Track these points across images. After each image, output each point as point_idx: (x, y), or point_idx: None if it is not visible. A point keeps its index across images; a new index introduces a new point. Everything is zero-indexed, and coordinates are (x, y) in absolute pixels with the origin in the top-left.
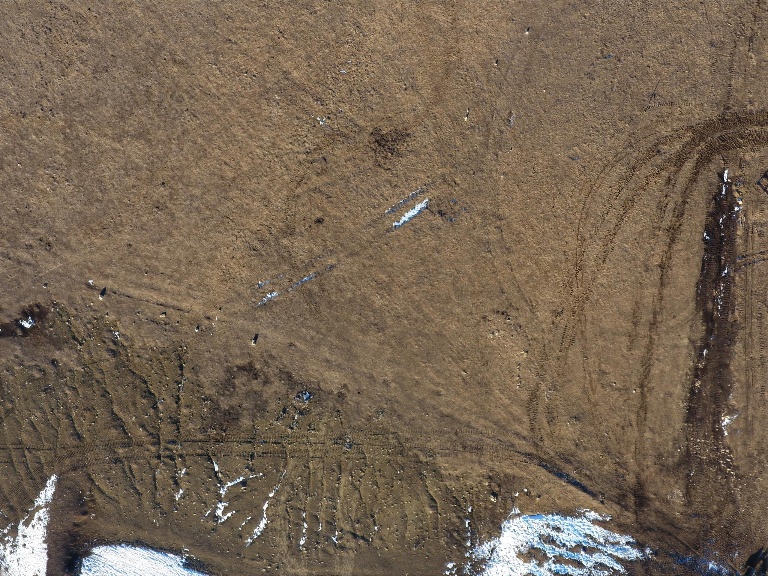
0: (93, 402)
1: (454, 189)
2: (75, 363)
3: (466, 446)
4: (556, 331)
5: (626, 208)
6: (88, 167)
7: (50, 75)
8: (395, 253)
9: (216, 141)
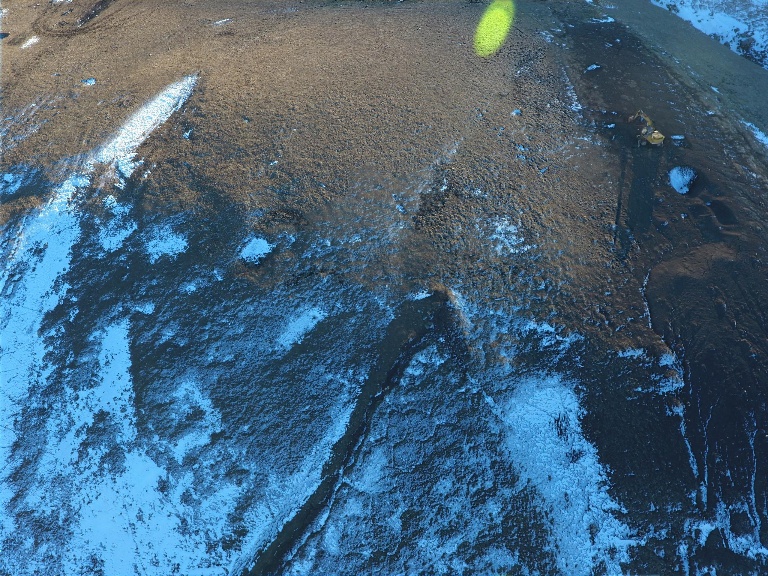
0: None
1: None
2: None
3: None
4: (171, 3)
5: None
6: None
7: None
8: None
9: None
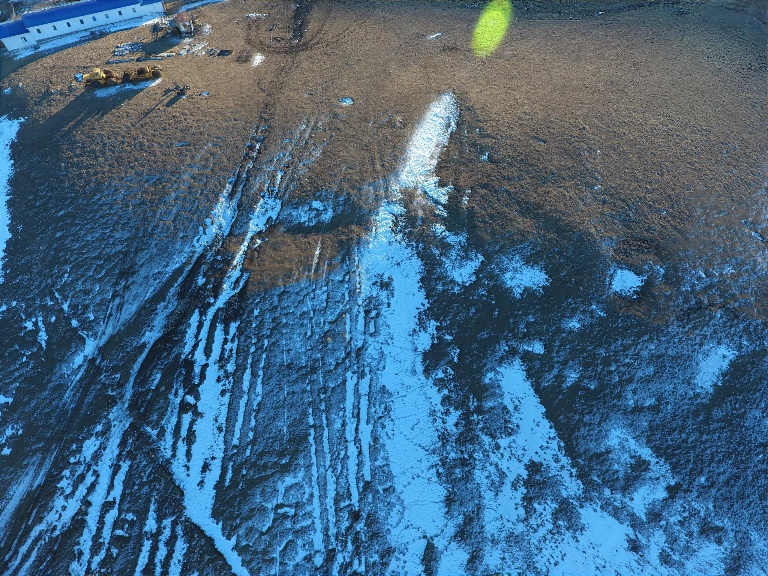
0: (563, 3)
1: None
2: (575, 8)
3: (401, 2)
4: None
5: None
6: None
7: None
8: None
9: None
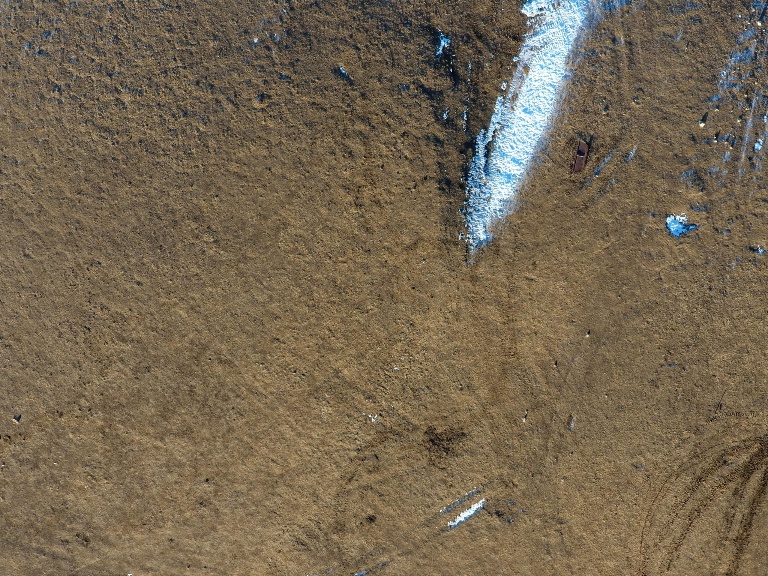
0: None
1: (512, 490)
2: None
3: None
4: None
5: (692, 518)
6: (128, 465)
7: (89, 375)
8: (450, 553)
9: (263, 439)
